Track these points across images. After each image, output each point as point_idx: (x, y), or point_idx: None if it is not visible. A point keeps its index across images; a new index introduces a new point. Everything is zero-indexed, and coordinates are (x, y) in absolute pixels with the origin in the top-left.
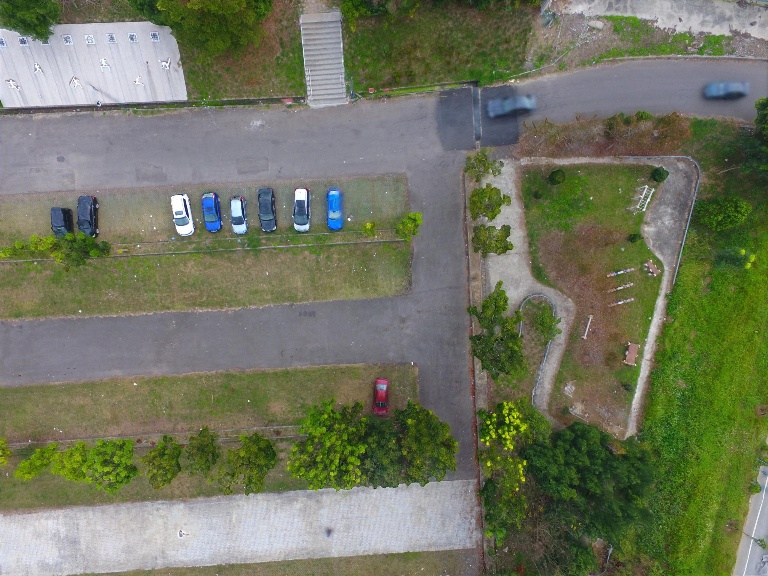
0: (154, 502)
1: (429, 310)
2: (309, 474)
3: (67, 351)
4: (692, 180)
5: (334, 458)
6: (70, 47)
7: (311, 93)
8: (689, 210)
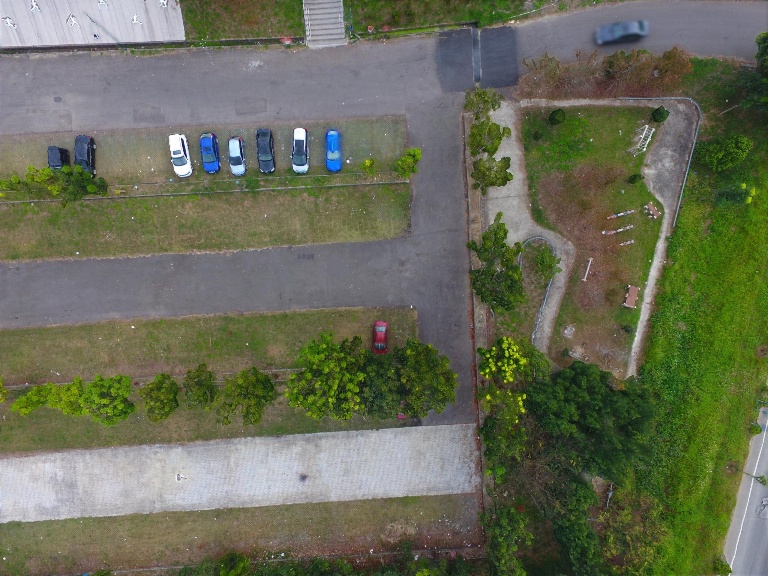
0: (152, 446)
1: (428, 253)
2: (307, 399)
3: (64, 293)
4: (692, 122)
5: (333, 384)
6: None
7: (310, 33)
8: (689, 152)
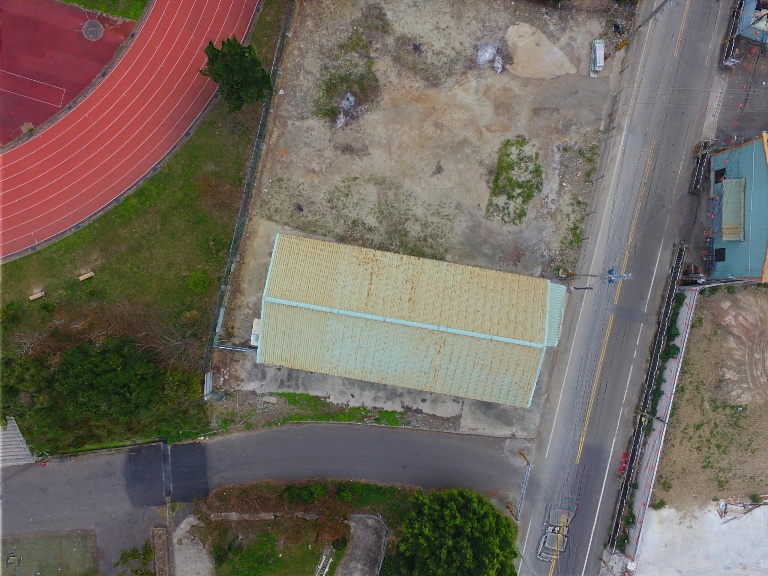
0: None
1: None
2: None
3: None
4: (382, 536)
5: None
6: None
7: None
8: (378, 567)
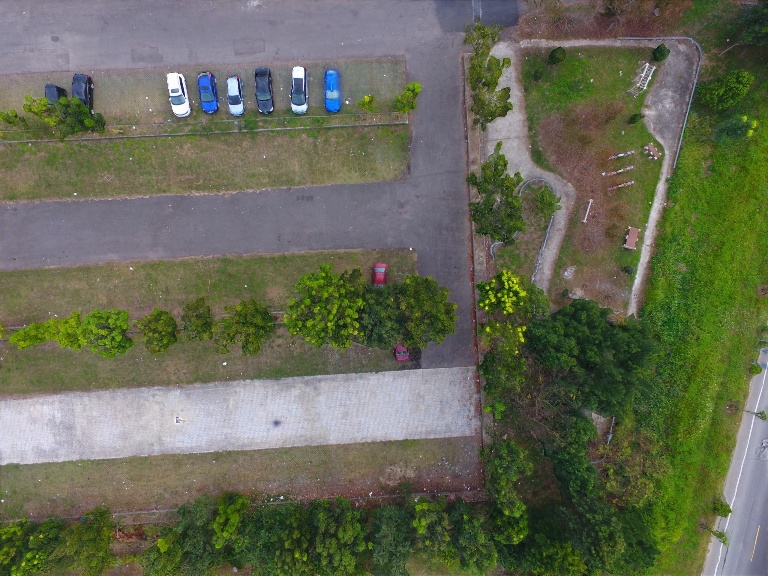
0: (150, 388)
1: (428, 195)
2: (306, 323)
3: (62, 234)
4: (693, 63)
5: (332, 308)
6: None
7: None
8: (690, 93)
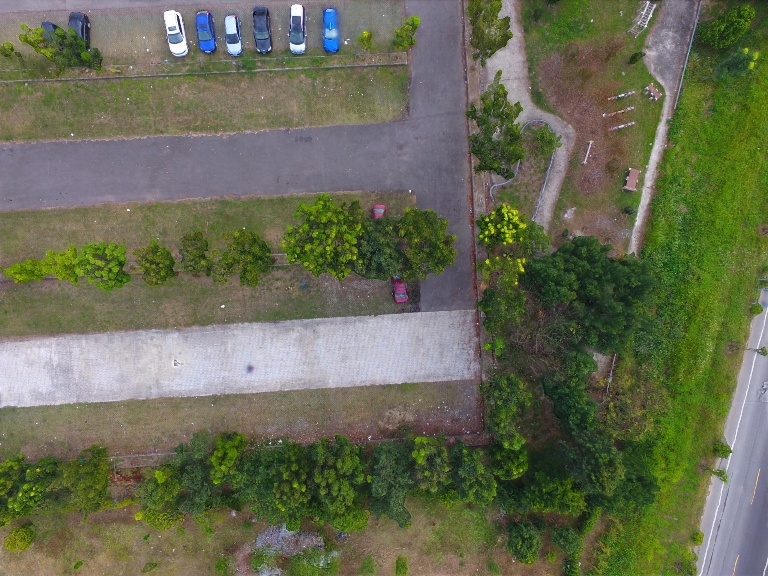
0: (148, 331)
1: (427, 136)
2: None
3: (59, 175)
4: (694, 3)
5: (330, 232)
6: None
7: None
8: (691, 33)
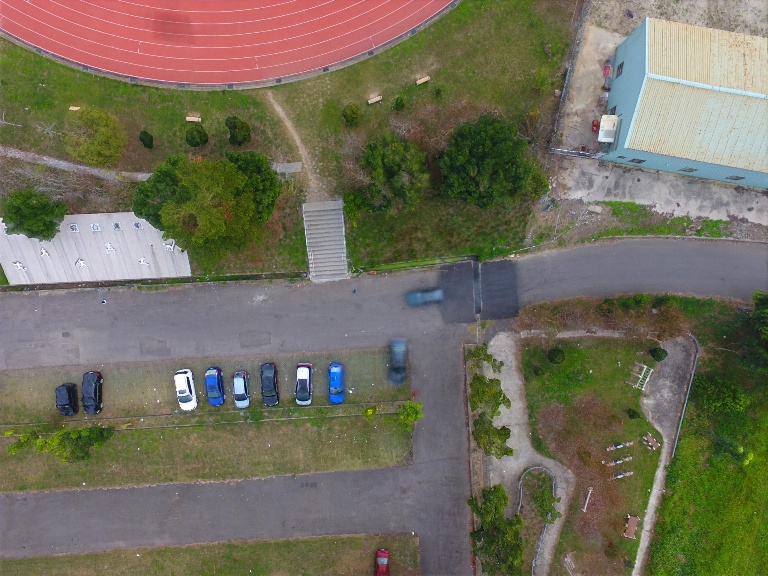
0: None
1: (430, 481)
2: None
3: (71, 523)
4: (691, 354)
5: None
6: (76, 234)
7: (313, 270)
8: (688, 384)
